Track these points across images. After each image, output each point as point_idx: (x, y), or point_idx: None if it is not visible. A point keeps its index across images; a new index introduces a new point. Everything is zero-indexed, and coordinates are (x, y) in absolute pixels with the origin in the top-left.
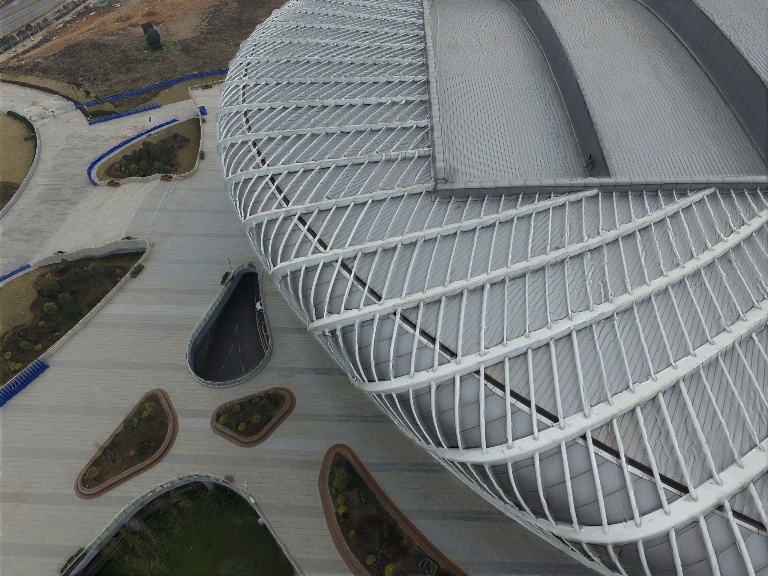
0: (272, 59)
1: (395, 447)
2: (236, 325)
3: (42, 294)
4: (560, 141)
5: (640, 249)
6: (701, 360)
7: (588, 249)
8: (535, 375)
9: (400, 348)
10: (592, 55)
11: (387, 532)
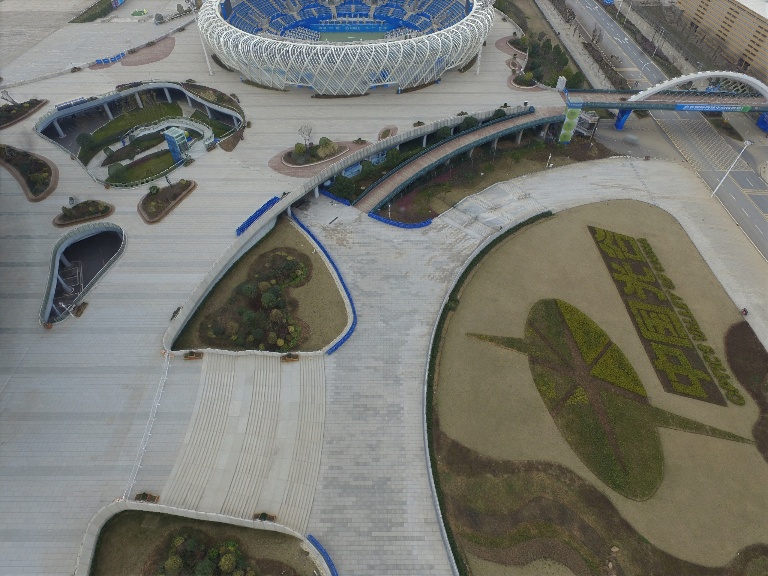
0: None
1: None
2: None
3: None
4: None
5: None
6: None
7: None
8: None
9: None
10: None
11: None
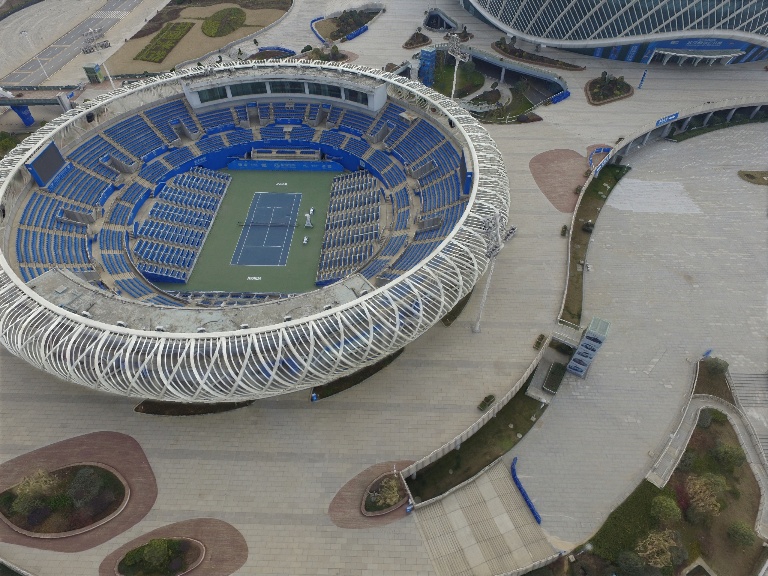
0: None
1: None
2: None
3: (343, 19)
4: None
5: None
6: None
7: None
8: None
9: None
10: None
11: None
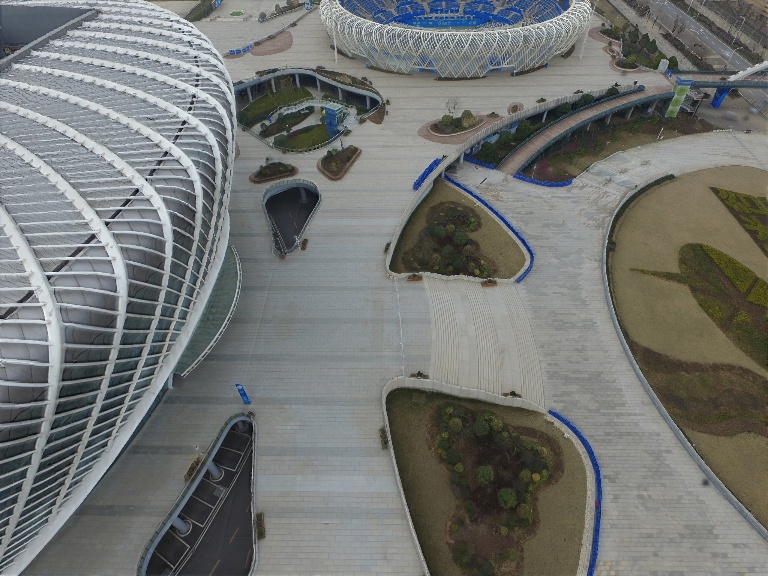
0: None
1: None
2: None
3: None
4: None
5: None
6: None
7: None
8: None
9: None
10: None
11: None
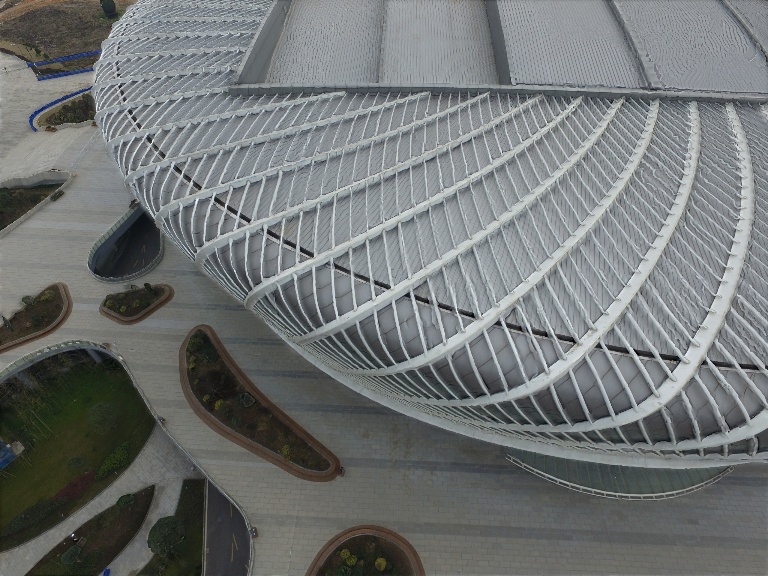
0: (155, 5)
1: (248, 327)
2: (144, 245)
3: None
4: (369, 72)
5: (352, 126)
6: (352, 185)
7: (317, 126)
8: (247, 197)
9: (169, 187)
10: (408, 7)
11: (223, 380)
